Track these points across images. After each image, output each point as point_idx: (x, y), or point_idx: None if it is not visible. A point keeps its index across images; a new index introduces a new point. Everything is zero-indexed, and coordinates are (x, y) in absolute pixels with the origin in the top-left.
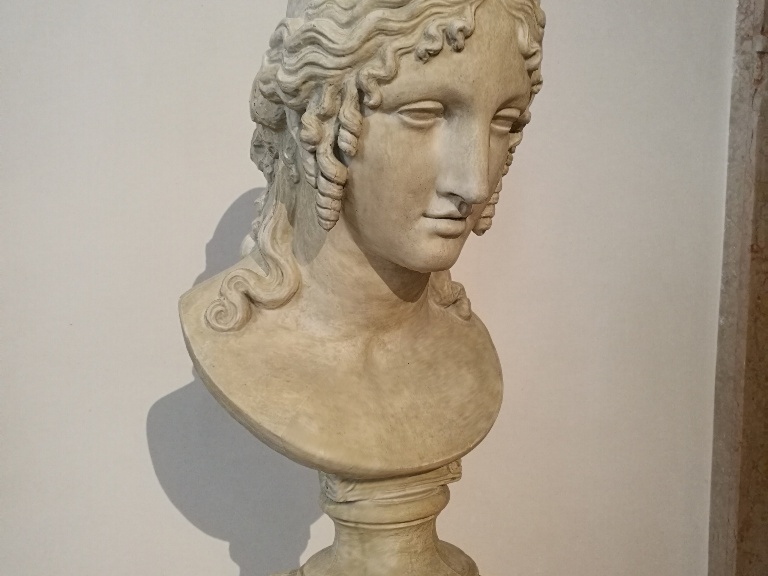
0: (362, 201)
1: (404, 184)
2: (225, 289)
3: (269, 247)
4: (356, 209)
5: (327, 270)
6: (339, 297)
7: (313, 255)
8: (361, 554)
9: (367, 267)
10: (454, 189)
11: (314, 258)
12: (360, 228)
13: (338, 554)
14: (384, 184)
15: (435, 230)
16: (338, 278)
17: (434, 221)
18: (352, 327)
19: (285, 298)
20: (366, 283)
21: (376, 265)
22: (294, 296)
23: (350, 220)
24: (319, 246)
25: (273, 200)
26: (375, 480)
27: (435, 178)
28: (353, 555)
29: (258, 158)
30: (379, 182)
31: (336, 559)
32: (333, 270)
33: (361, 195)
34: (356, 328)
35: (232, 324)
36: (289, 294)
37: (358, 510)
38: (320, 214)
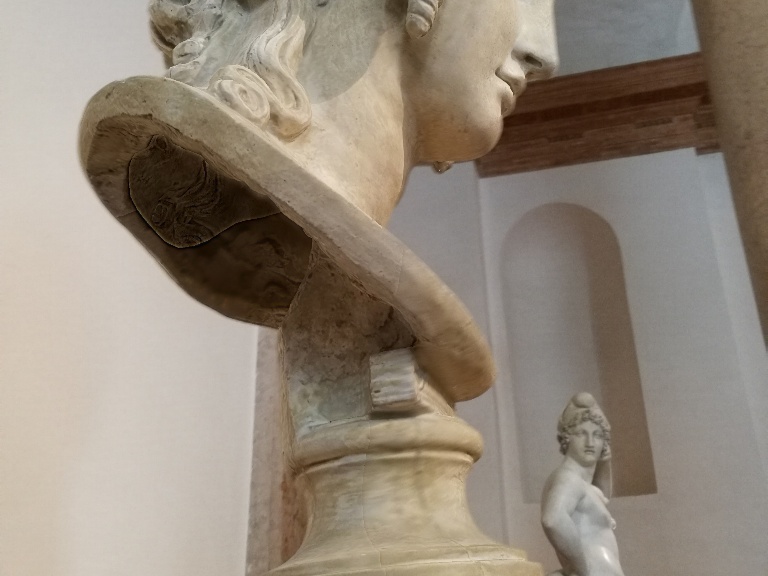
0: (450, 26)
1: (502, 21)
2: (237, 74)
3: (277, 62)
4: (435, 36)
5: (358, 111)
6: (361, 153)
7: (340, 89)
8: (420, 507)
9: (399, 127)
10: (536, 51)
11: (341, 93)
12: (428, 62)
13: (372, 520)
14: (486, 11)
15: (504, 91)
16: (370, 125)
17: (503, 82)
18: (363, 201)
19: (302, 126)
20: (393, 146)
21: (405, 130)
22: (298, 137)
23: (415, 51)
24: (353, 79)
25: (281, 15)
26: (435, 386)
27: (517, 35)
28: (407, 511)
29: (176, 6)
30: (482, 7)
31: (373, 527)
32: (366, 113)
33: (452, 18)
34: (365, 205)
35: (259, 114)
36: (306, 124)
37: (430, 422)
38: (423, 9)
